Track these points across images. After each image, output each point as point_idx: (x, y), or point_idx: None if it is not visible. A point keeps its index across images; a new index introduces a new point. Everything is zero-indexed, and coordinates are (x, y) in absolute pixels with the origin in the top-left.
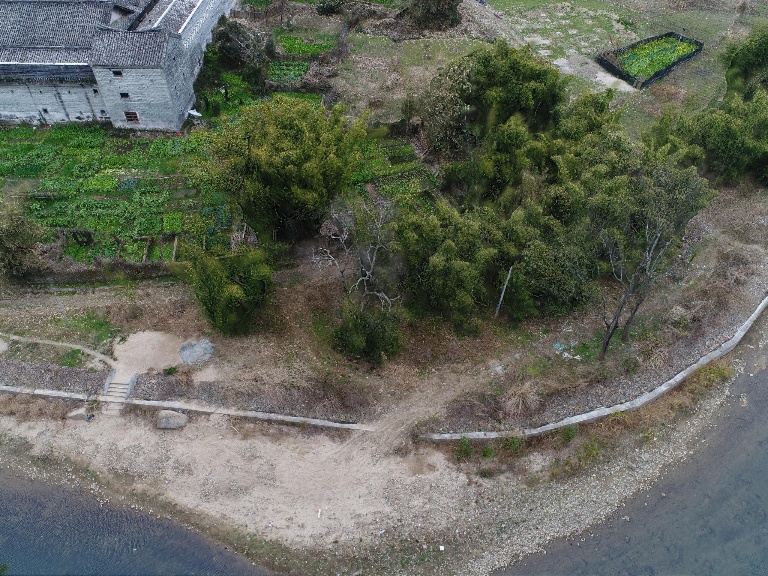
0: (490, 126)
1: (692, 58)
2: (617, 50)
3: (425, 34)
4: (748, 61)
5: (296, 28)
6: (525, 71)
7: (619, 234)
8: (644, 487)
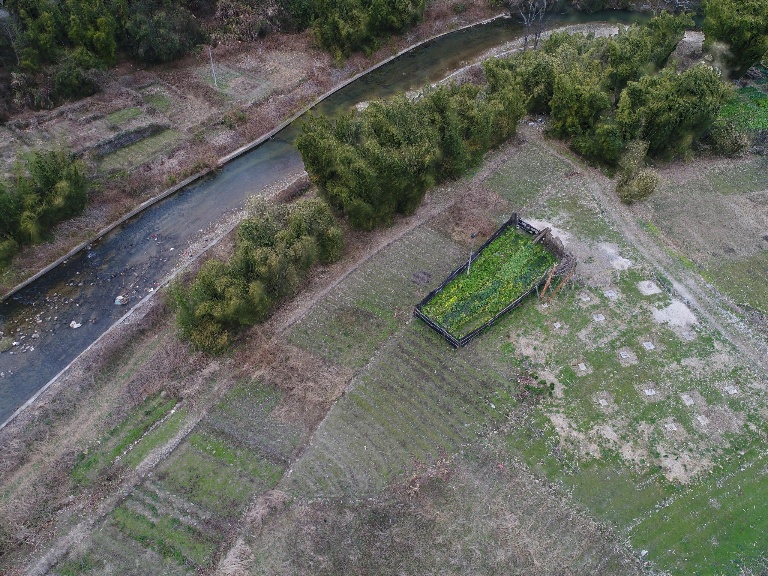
0: None
1: (432, 298)
2: None
3: None
4: None
5: None
6: None
7: (541, 50)
8: None
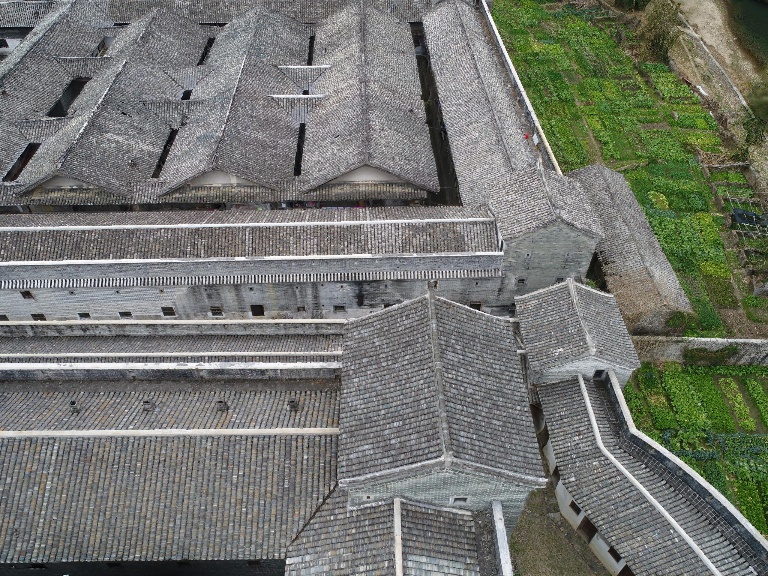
0: None
1: None
2: None
3: None
4: None
5: None
6: None
7: None
8: None
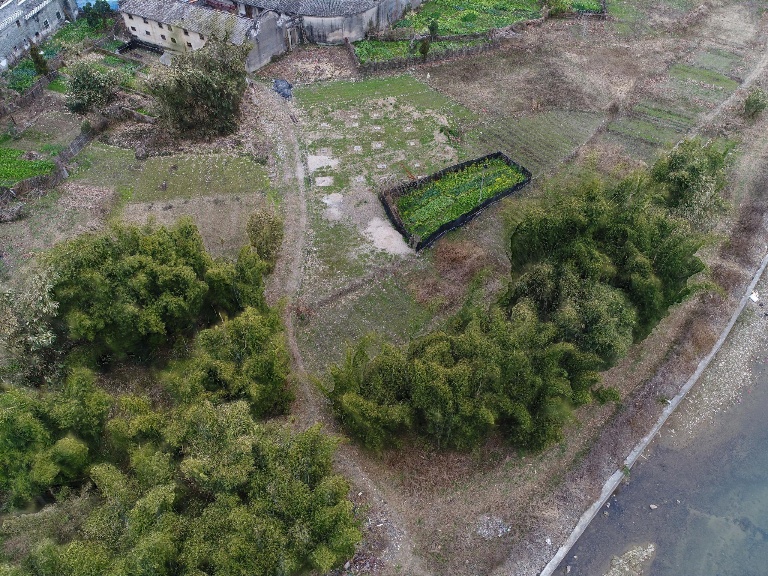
0: (114, 351)
1: (514, 193)
2: (409, 184)
3: (183, 147)
4: (521, 246)
5: (27, 134)
6: (153, 279)
7: None
8: None
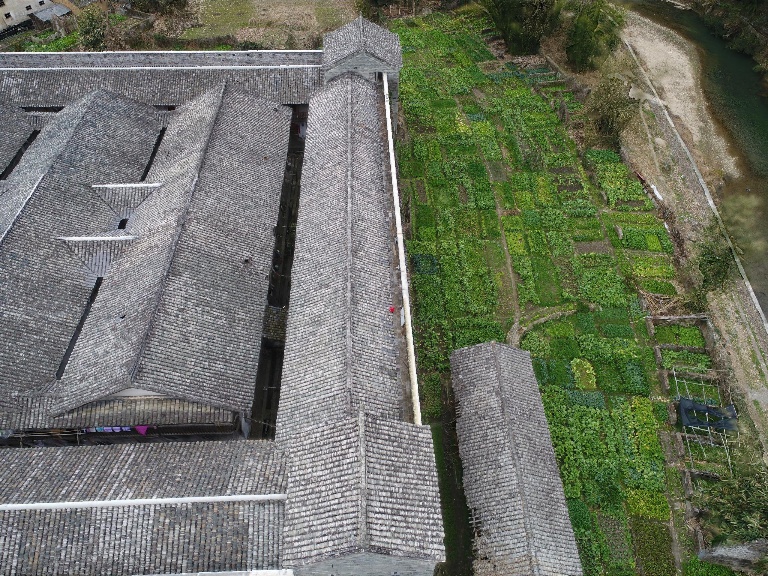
0: None
1: None
2: None
3: None
4: None
5: None
6: None
7: None
8: (607, 1)
